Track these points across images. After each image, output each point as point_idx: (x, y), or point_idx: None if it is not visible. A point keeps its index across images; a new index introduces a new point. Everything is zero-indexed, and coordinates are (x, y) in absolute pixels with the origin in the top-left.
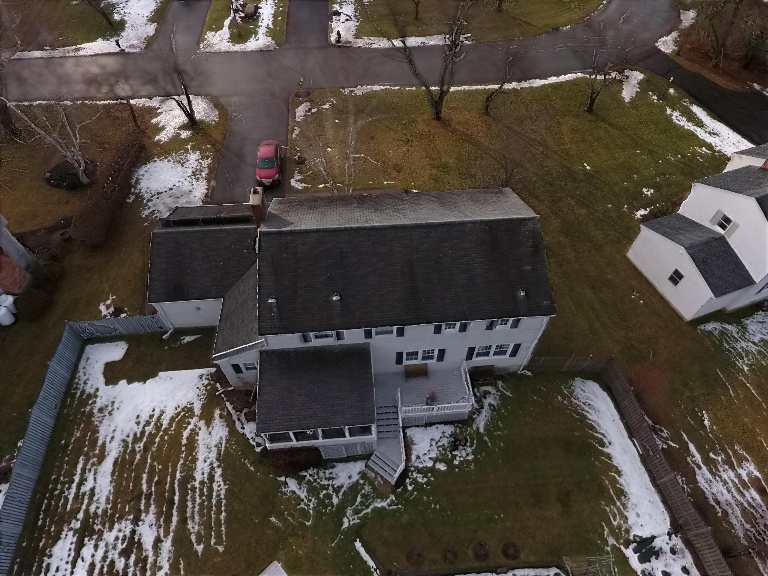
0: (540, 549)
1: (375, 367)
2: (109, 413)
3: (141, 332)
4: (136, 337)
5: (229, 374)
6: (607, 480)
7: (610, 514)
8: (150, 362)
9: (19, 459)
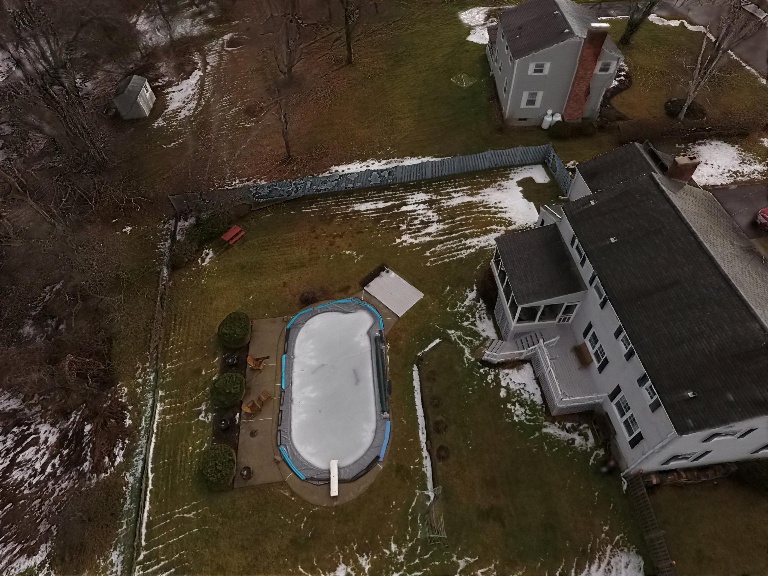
0: (447, 481)
1: (575, 320)
2: (499, 189)
3: (560, 185)
4: (555, 184)
5: (538, 226)
6: (522, 574)
7: (487, 569)
8: (539, 196)
9: (462, 157)
